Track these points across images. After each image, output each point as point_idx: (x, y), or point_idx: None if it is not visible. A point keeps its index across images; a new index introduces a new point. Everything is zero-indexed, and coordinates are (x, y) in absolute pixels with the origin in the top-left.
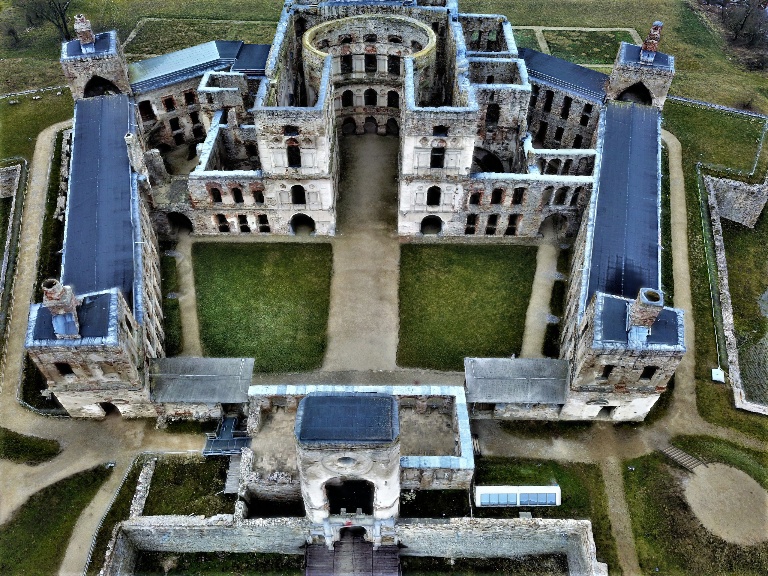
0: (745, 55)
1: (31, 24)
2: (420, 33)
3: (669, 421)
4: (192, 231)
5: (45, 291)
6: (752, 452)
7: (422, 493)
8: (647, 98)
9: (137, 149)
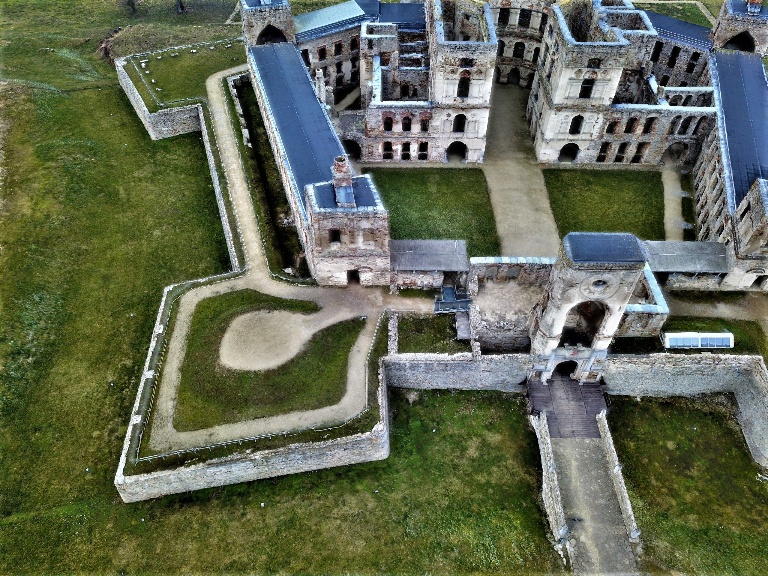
0: None
1: None
2: None
3: None
4: (359, 158)
5: (338, 164)
6: None
7: (619, 339)
8: (747, 48)
9: (323, 83)
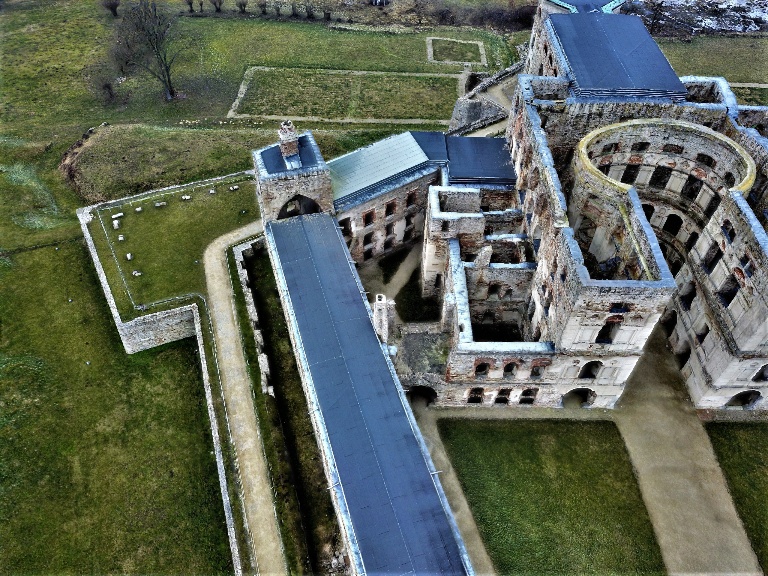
0: None
1: (122, 73)
2: (719, 147)
3: None
4: (432, 402)
5: None
6: None
7: None
8: None
9: None
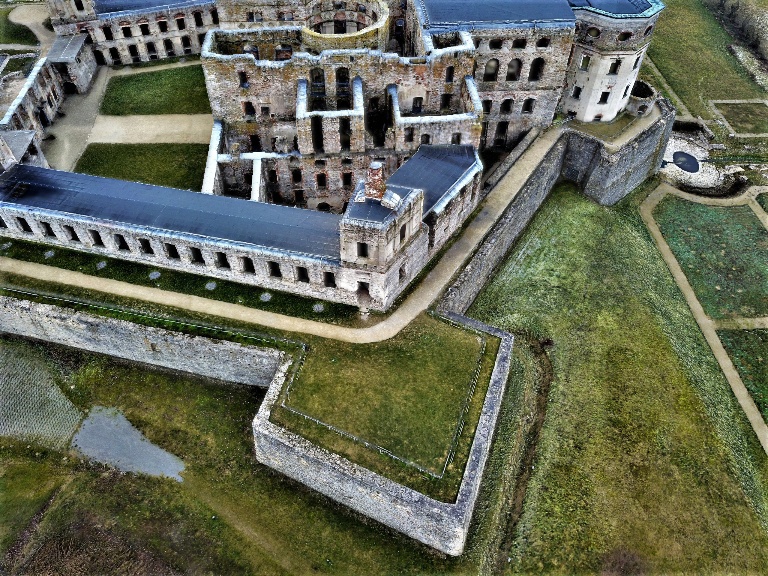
0: None
1: None
2: None
3: None
4: None
5: None
6: None
7: None
8: None
9: None
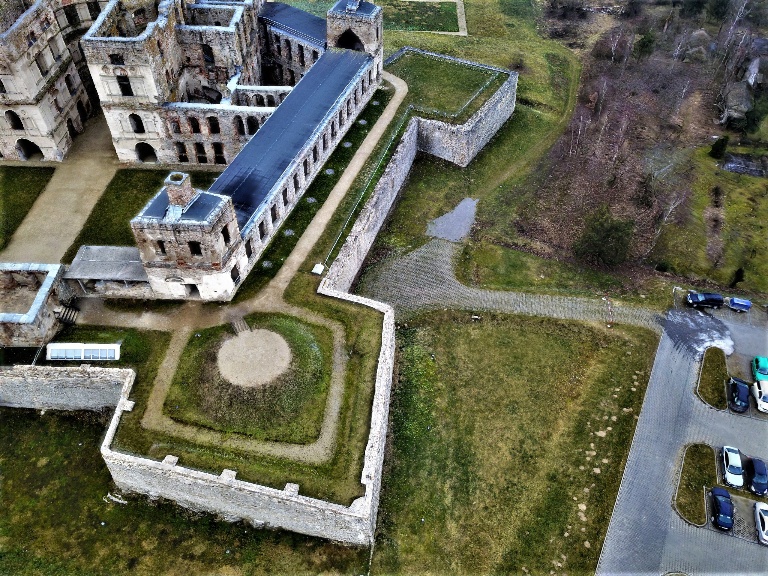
0: (553, 25)
1: None
2: None
3: (253, 302)
4: None
5: None
6: (311, 326)
7: (6, 349)
8: None
9: None
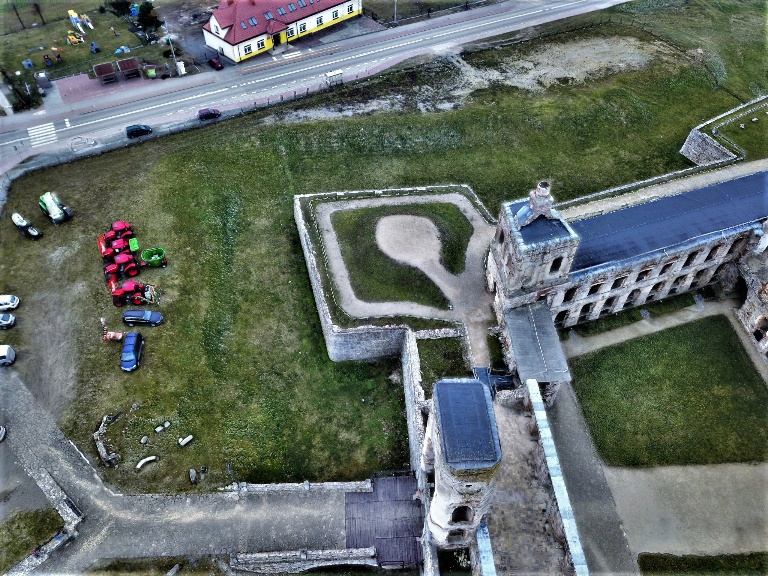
0: None
1: None
2: None
3: None
4: (739, 309)
5: None
6: None
7: (469, 574)
8: None
9: None
